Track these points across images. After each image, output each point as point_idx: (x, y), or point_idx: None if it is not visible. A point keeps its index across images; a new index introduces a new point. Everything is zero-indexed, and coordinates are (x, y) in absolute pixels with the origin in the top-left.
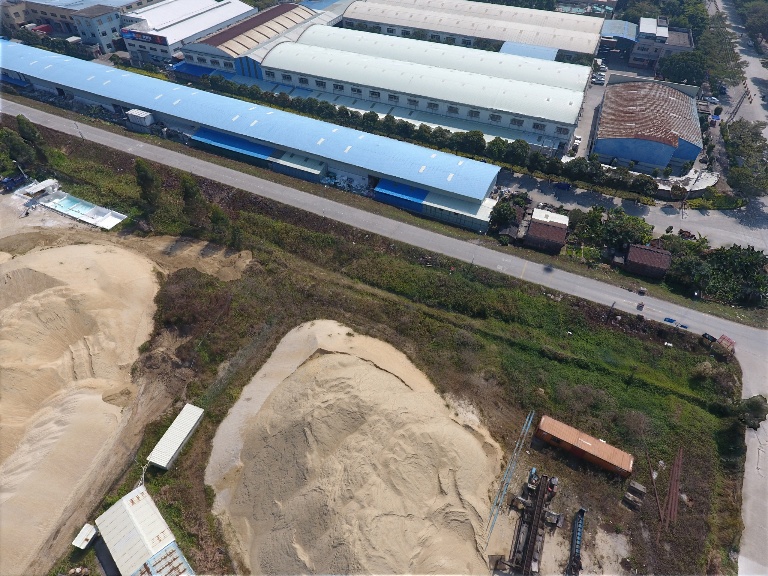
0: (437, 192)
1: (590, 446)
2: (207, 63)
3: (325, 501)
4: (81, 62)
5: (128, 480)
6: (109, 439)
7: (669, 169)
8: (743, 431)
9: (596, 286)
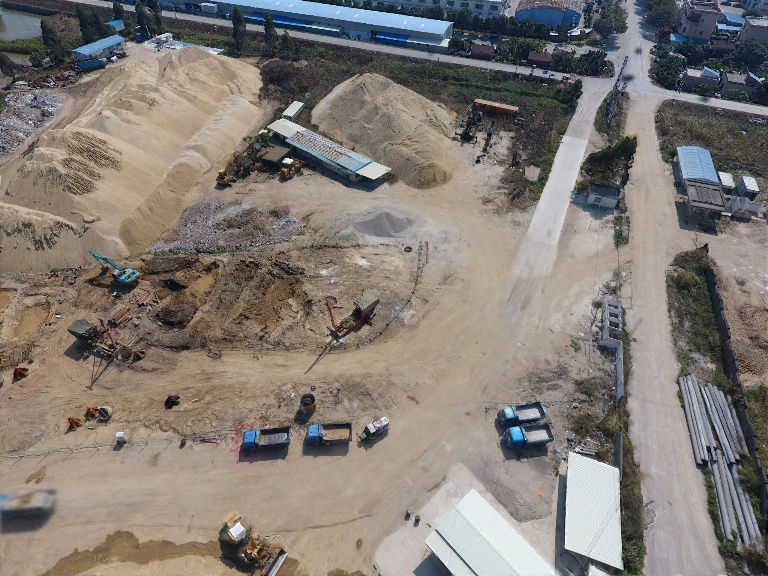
0: (415, 36)
1: (498, 105)
2: None
3: (376, 104)
4: None
5: None
6: (257, 116)
7: (560, 25)
8: (575, 105)
9: (509, 67)
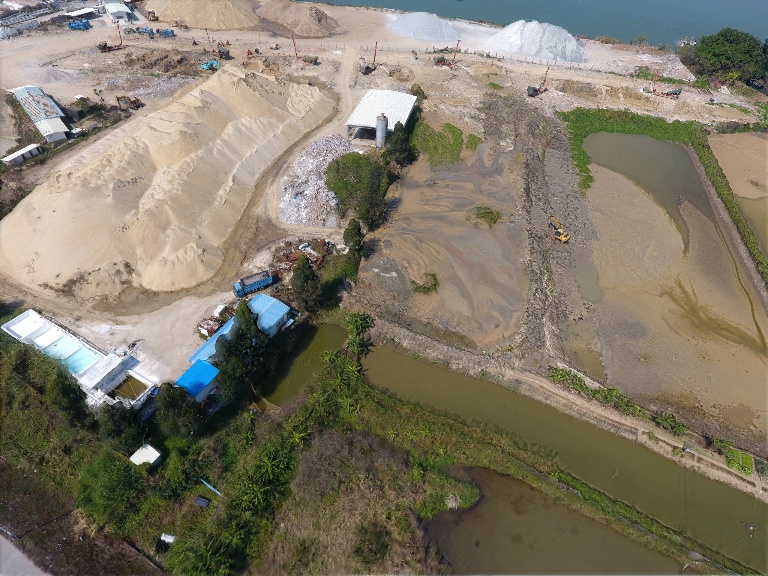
0: None
1: None
2: None
3: None
4: None
5: (58, 149)
6: None
7: None
8: None
9: None
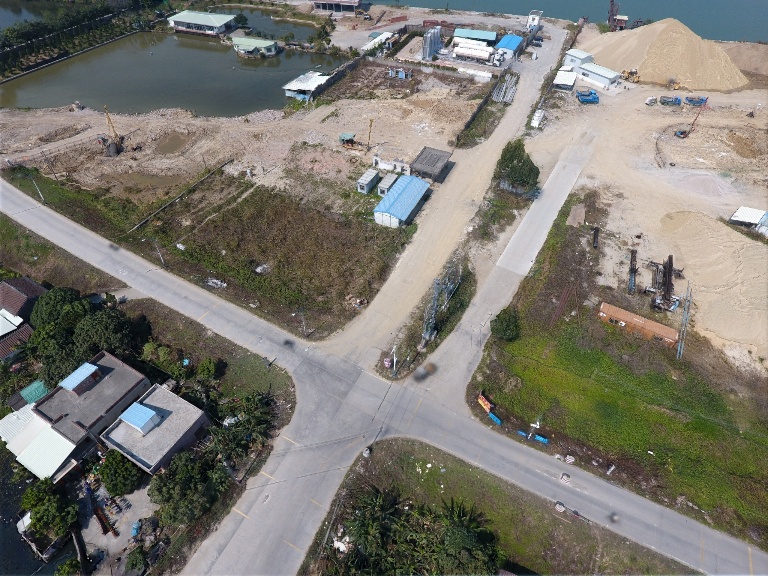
0: None
1: (635, 318)
2: None
3: None
4: None
5: None
6: None
7: None
8: None
9: (628, 524)
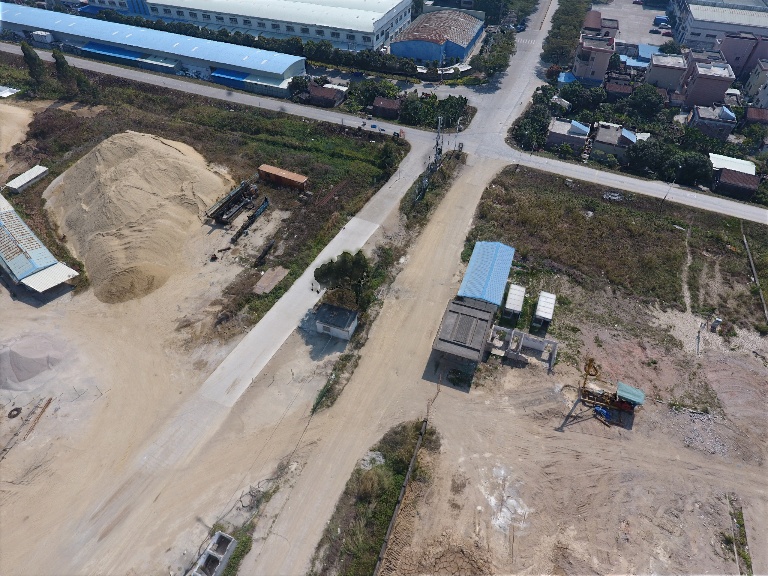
0: (255, 74)
1: (284, 174)
2: (106, 4)
3: (99, 179)
4: (0, 3)
5: None
6: None
7: (435, 60)
8: (391, 173)
9: (341, 116)
